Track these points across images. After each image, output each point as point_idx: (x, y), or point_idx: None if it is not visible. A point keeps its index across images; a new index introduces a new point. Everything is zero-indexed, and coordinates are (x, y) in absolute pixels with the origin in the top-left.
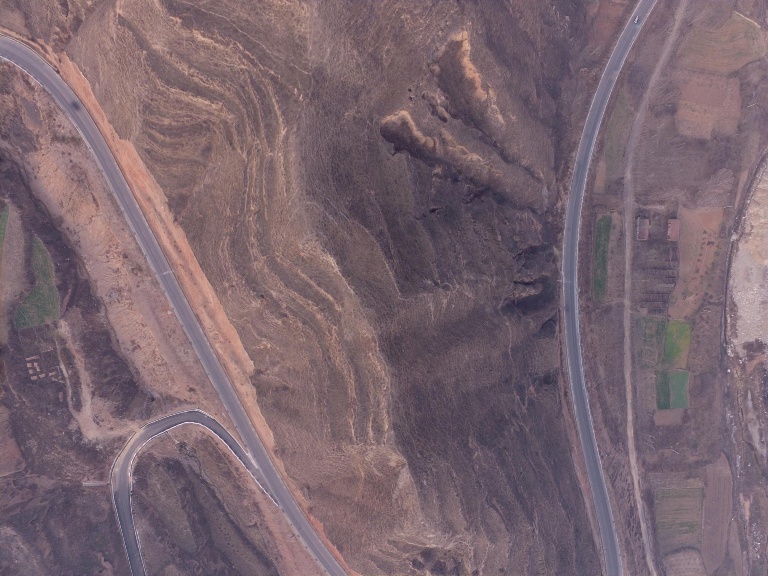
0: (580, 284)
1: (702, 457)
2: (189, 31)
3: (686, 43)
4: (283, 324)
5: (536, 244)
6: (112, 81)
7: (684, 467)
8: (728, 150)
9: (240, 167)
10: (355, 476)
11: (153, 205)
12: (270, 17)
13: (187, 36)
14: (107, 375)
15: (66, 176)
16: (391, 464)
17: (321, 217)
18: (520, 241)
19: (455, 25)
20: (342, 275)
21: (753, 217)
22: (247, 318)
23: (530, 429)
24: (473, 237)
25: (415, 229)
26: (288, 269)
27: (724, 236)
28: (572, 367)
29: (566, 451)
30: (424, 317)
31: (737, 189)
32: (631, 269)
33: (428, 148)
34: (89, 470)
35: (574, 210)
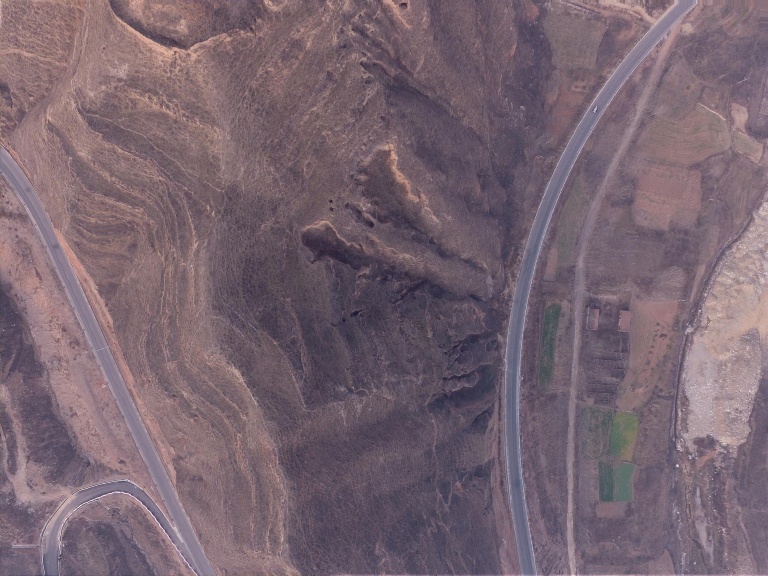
0: (523, 372)
1: (645, 552)
2: (110, 143)
3: (647, 133)
4: (195, 422)
5: (477, 333)
6: (46, 176)
7: (625, 561)
8: (686, 243)
9: (159, 270)
10: (262, 573)
11: (89, 286)
12: (185, 137)
13: (109, 147)
14: (44, 439)
15: (12, 250)
16: (287, 574)
17: (227, 331)
18: (455, 335)
19: (379, 139)
20: (247, 386)
21: (710, 311)
22: (164, 411)
23: (451, 528)
24: (398, 337)
25: (331, 336)
26: (196, 375)
27: (677, 330)
28: (510, 456)
29: (491, 548)
30: (334, 424)
31: (693, 283)
32: (579, 358)
33: (356, 249)
34: (19, 533)
35: (521, 298)
